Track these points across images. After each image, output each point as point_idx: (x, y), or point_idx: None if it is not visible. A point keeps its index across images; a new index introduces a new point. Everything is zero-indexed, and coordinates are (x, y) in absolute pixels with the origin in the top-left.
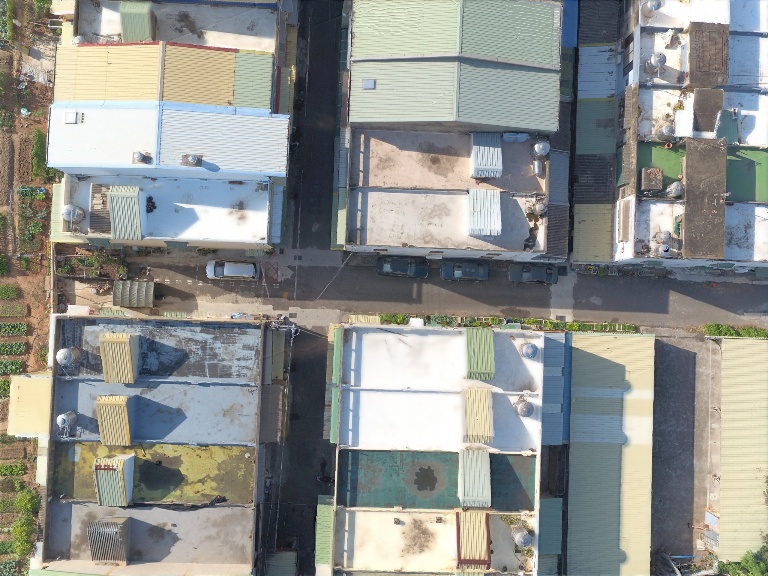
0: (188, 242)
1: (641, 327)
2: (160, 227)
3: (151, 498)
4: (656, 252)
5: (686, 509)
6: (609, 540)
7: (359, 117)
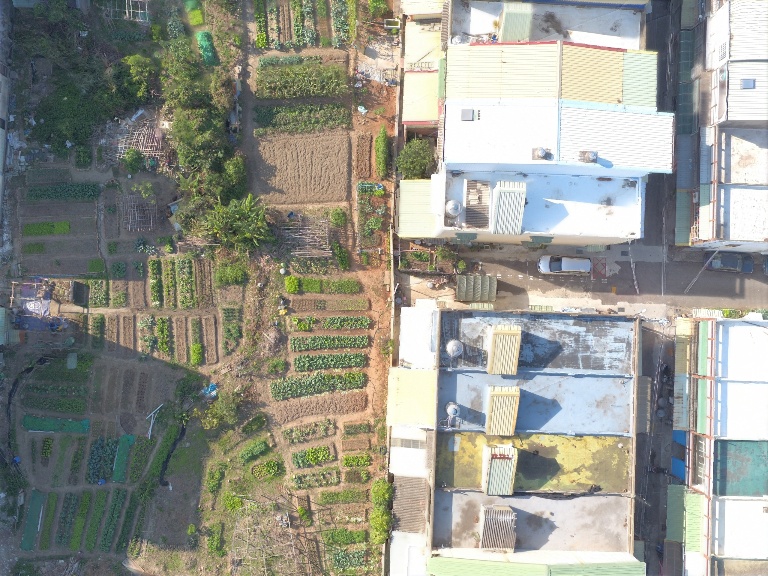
0: (553, 237)
1: None
2: (532, 222)
3: (529, 487)
4: None
5: None
6: None
7: (738, 115)
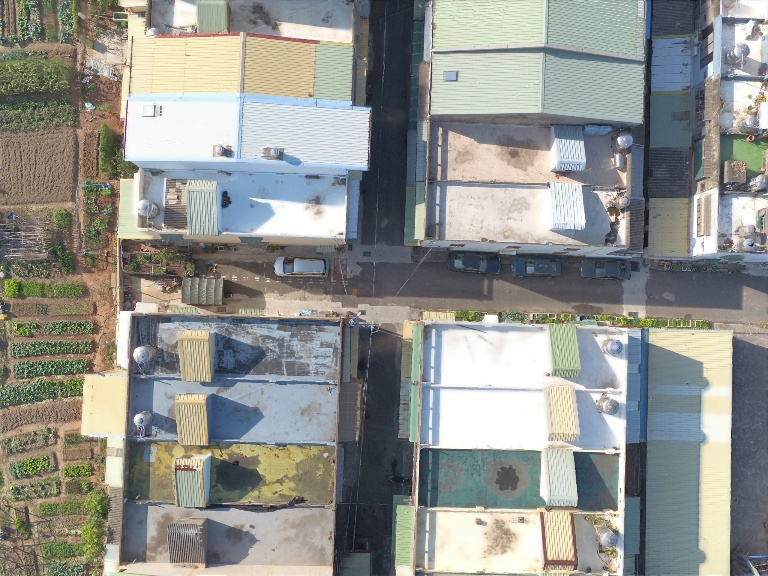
0: (263, 238)
1: (715, 323)
2: (235, 222)
3: (228, 499)
4: (740, 246)
5: (762, 508)
6: (688, 540)
7: (441, 109)
